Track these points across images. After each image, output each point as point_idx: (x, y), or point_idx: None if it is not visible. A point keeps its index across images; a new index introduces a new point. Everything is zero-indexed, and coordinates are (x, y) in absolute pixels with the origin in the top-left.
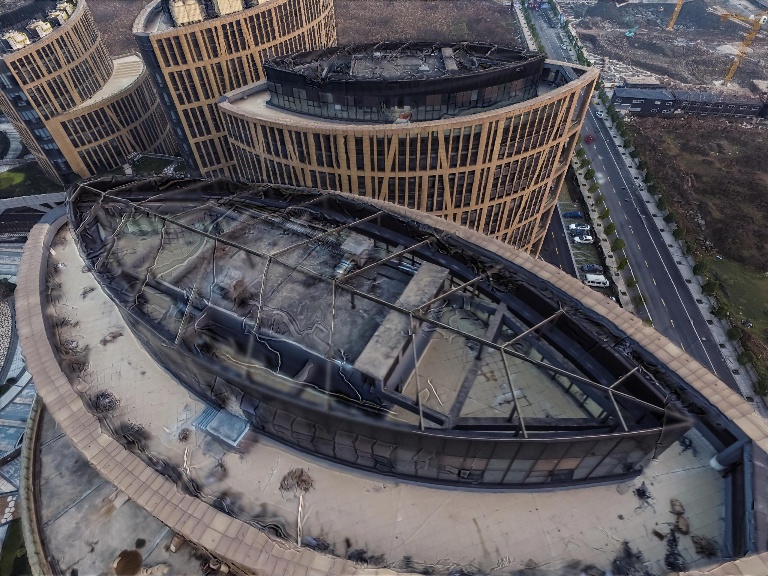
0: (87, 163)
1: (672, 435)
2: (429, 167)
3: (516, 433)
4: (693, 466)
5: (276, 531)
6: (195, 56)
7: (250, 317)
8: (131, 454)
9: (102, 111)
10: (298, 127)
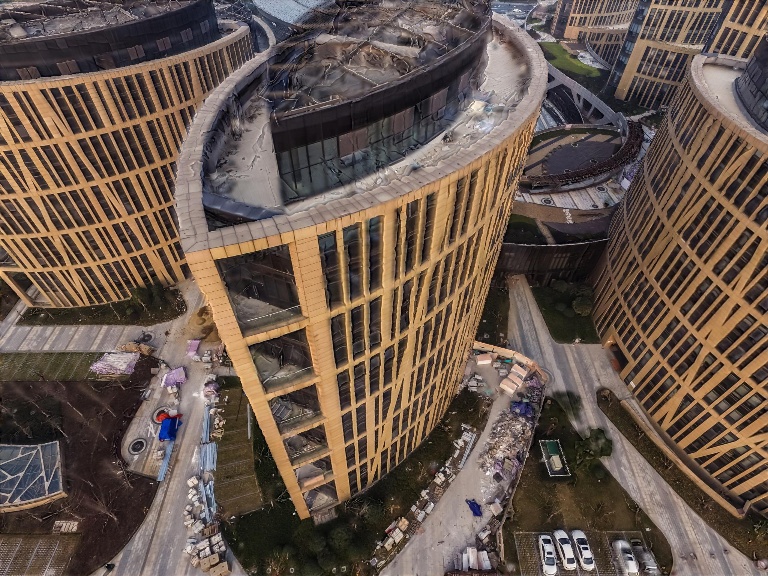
0: (632, 89)
1: (303, 194)
2: (757, 217)
3: (288, 93)
4: (277, 202)
5: (265, 85)
6: (766, 23)
7: (351, 2)
8: (301, 41)
9: (685, 57)
10: (699, 91)
